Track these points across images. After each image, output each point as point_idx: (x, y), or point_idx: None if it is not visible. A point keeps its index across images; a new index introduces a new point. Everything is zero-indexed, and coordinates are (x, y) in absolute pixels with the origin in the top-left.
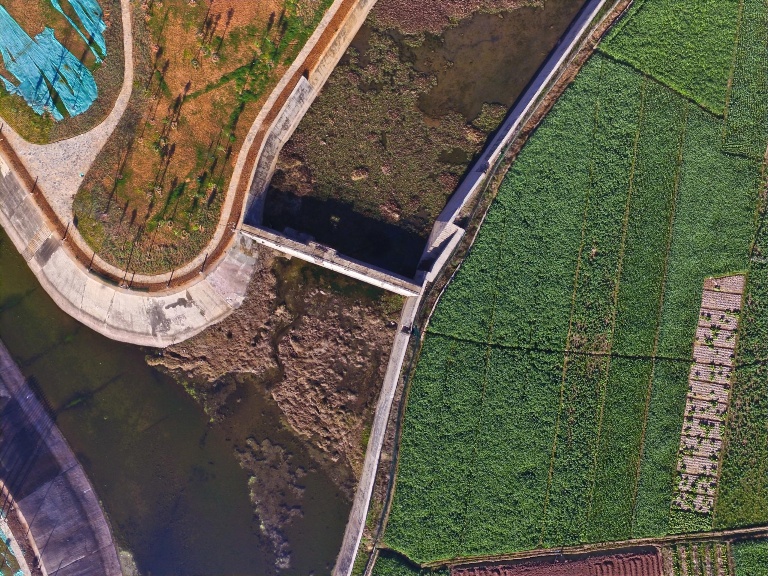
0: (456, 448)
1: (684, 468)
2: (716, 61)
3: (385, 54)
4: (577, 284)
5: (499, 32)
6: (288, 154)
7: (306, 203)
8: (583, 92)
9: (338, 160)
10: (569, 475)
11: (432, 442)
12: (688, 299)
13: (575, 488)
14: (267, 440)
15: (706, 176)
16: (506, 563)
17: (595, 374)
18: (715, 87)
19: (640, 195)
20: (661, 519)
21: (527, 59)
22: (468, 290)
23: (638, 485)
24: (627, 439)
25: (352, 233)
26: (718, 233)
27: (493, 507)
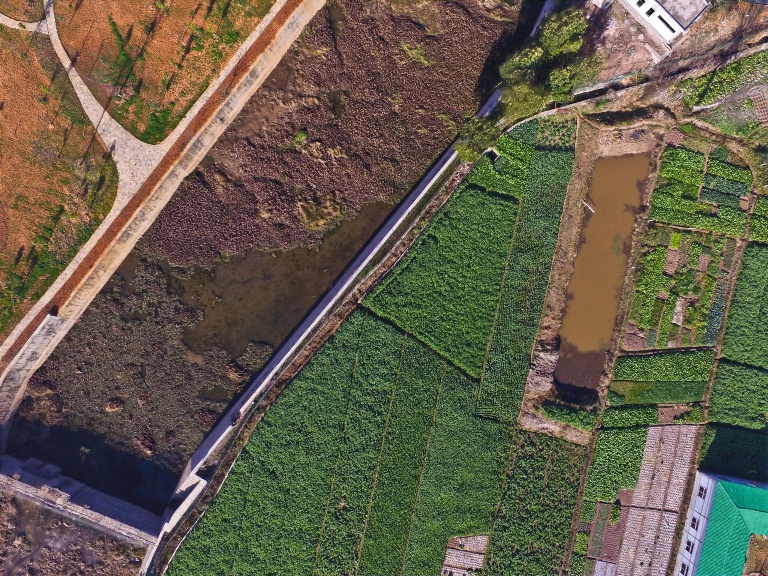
0: None
1: None
2: (475, 326)
3: (151, 284)
4: (321, 538)
5: (272, 271)
6: (39, 381)
7: (55, 432)
8: (341, 348)
9: (93, 390)
10: None
11: None
12: (430, 558)
13: None
14: None
15: (456, 439)
16: None
17: None
18: (472, 352)
19: (391, 453)
20: None
21: (298, 300)
22: (209, 540)
23: None
24: None
25: (102, 465)
26: (464, 495)
27: None
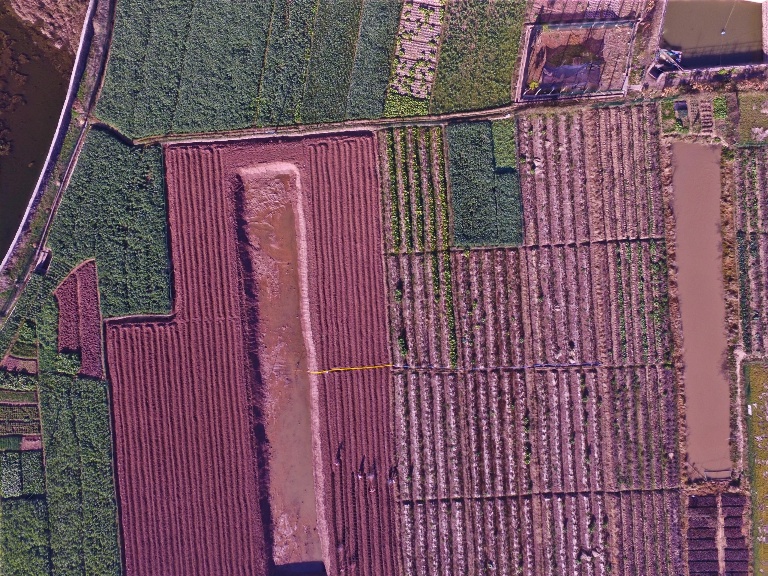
0: (170, 21)
1: (401, 51)
2: None
3: None
4: None
5: None
6: None
7: None
8: None
9: None
10: (284, 52)
11: (145, 13)
12: None
13: (290, 67)
14: None
15: None
16: (220, 143)
17: None
18: None
19: None
20: (376, 100)
21: None
22: None
23: None
24: (344, 19)
25: None
26: None
27: (205, 81)
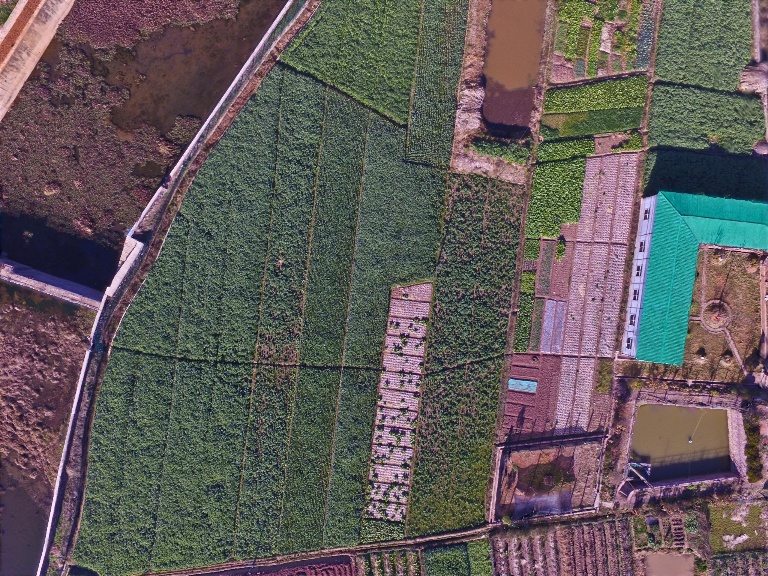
0: (143, 463)
1: (375, 477)
2: (396, 71)
3: (76, 68)
4: (263, 295)
5: (192, 45)
6: None
7: None
8: (264, 104)
9: (30, 175)
10: (258, 487)
11: (118, 457)
12: (374, 308)
13: (265, 500)
14: None
15: (388, 185)
16: None
17: (284, 385)
18: (396, 97)
19: (324, 205)
20: (352, 529)
21: (221, 71)
22: (152, 304)
23: (328, 495)
24: (317, 449)
25: (46, 248)
26: (402, 242)
27: (181, 521)
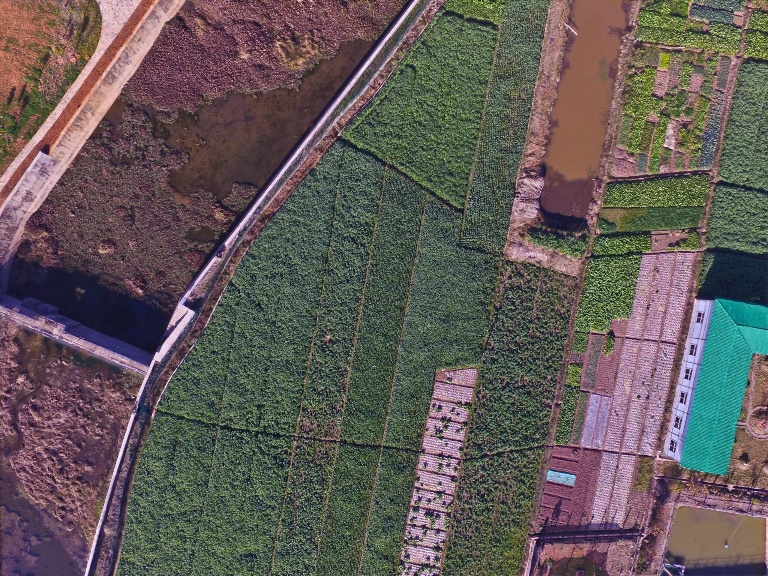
0: (179, 527)
1: (407, 558)
2: (457, 155)
3: (138, 129)
4: (308, 370)
5: (253, 112)
6: (35, 224)
7: (52, 273)
8: (322, 179)
9: (86, 232)
10: (291, 559)
11: (156, 520)
12: (418, 390)
13: (297, 572)
14: (3, 507)
15: (440, 269)
16: None
17: (323, 460)
18: (454, 181)
19: (375, 284)
20: None
21: (280, 140)
22: (198, 371)
23: (359, 573)
24: (351, 526)
25: (97, 305)
26: (450, 326)
27: None
